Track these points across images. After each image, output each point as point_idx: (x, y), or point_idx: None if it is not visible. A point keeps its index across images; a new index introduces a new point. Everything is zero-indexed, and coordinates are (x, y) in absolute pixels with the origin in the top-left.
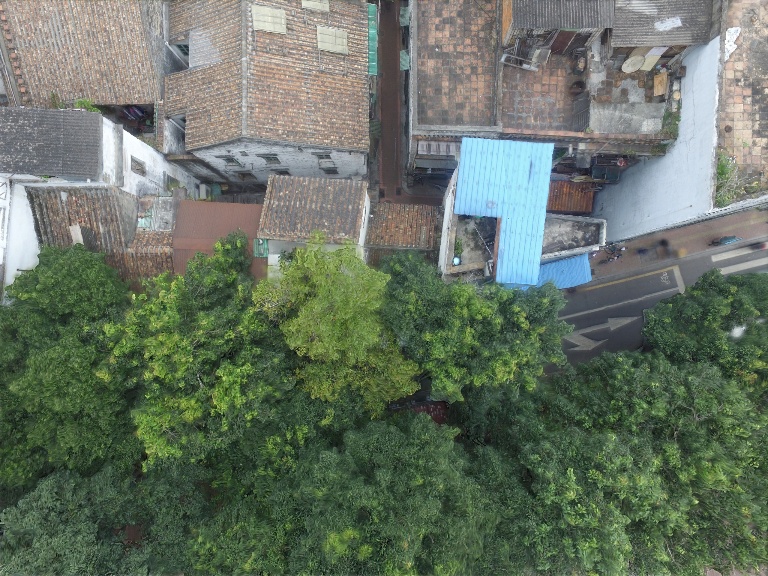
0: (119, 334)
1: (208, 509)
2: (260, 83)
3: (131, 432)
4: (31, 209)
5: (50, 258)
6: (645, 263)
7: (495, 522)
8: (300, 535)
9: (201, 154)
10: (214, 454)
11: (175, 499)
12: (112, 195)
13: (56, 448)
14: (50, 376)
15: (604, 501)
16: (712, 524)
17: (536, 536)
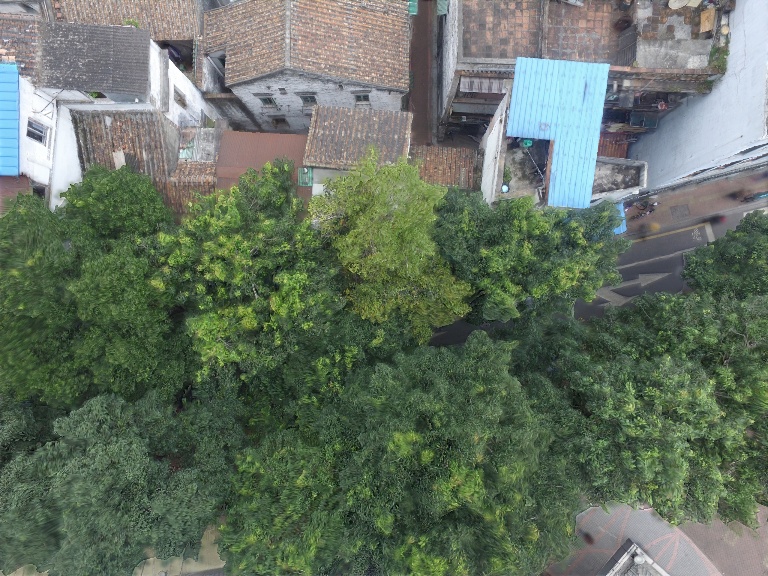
0: (172, 245)
1: (246, 445)
2: (303, 15)
3: (174, 359)
4: (75, 134)
5: (99, 176)
6: (677, 219)
7: (549, 440)
8: (348, 458)
9: (240, 91)
10: (253, 389)
11: (216, 430)
12: (157, 120)
13: (102, 369)
14: (108, 279)
15: (662, 416)
16: (761, 454)
17: (591, 453)
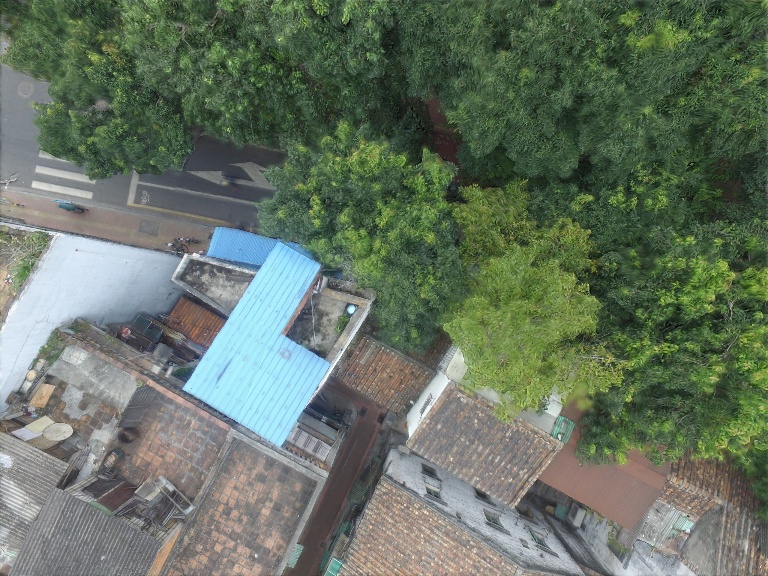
0: None
1: (740, 169)
2: None
3: None
4: None
5: None
6: (157, 221)
7: (450, 6)
8: None
9: (574, 568)
10: None
11: None
12: None
13: None
14: None
15: None
16: None
17: None
